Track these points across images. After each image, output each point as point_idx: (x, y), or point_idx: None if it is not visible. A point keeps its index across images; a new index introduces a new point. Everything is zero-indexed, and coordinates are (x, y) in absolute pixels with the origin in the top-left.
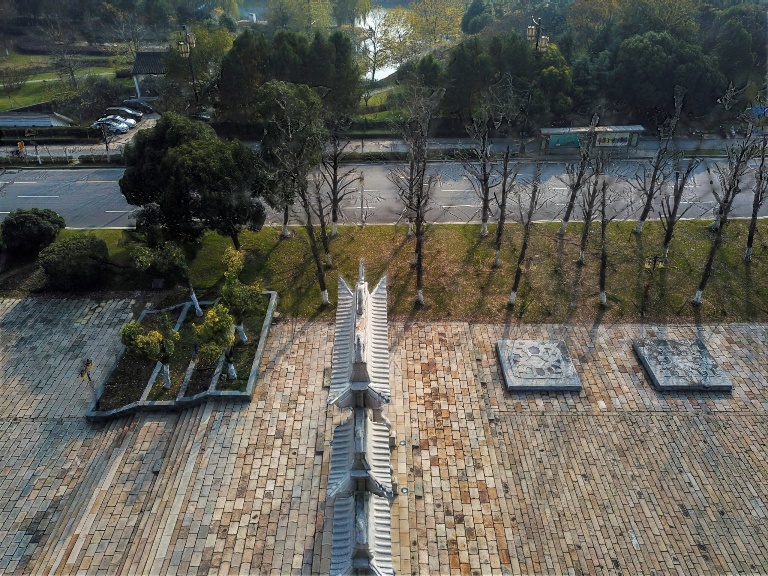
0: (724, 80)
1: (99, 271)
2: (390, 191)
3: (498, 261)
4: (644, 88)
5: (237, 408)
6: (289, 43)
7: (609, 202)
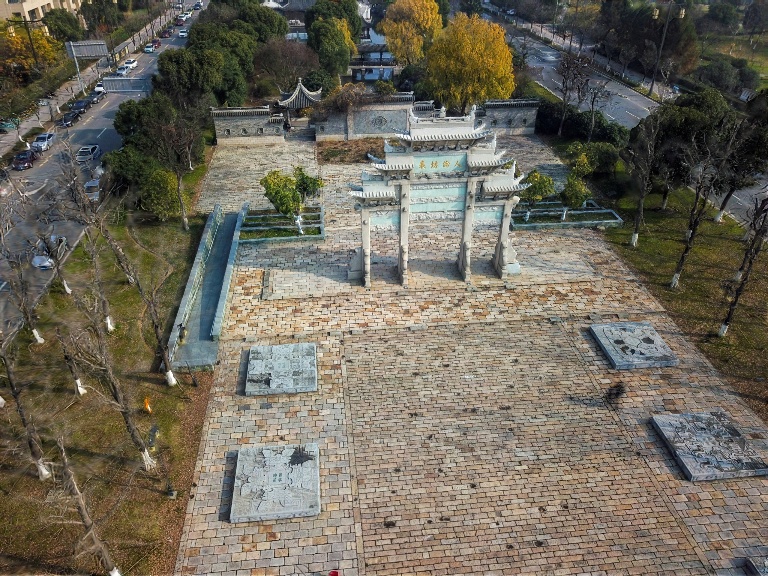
0: None
1: (597, 168)
2: None
3: None
4: None
5: None
6: None
7: None
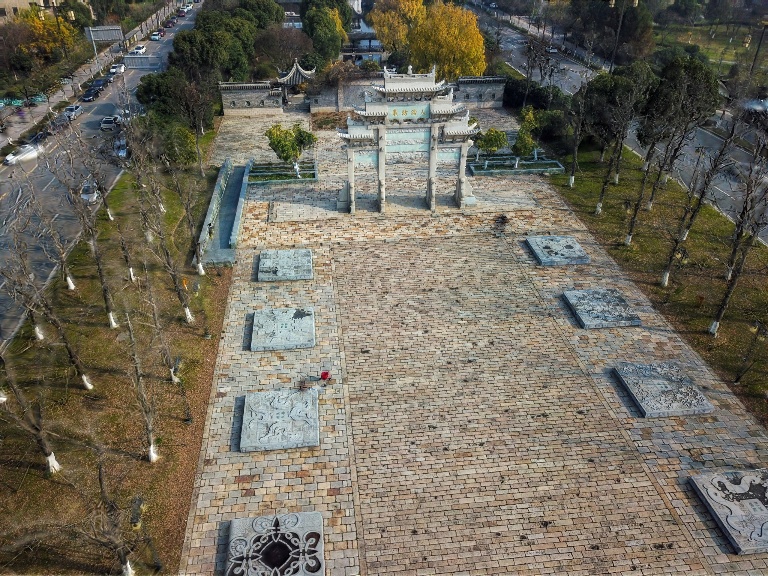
0: None
1: (550, 132)
2: None
3: None
4: None
5: (467, 174)
6: None
7: None
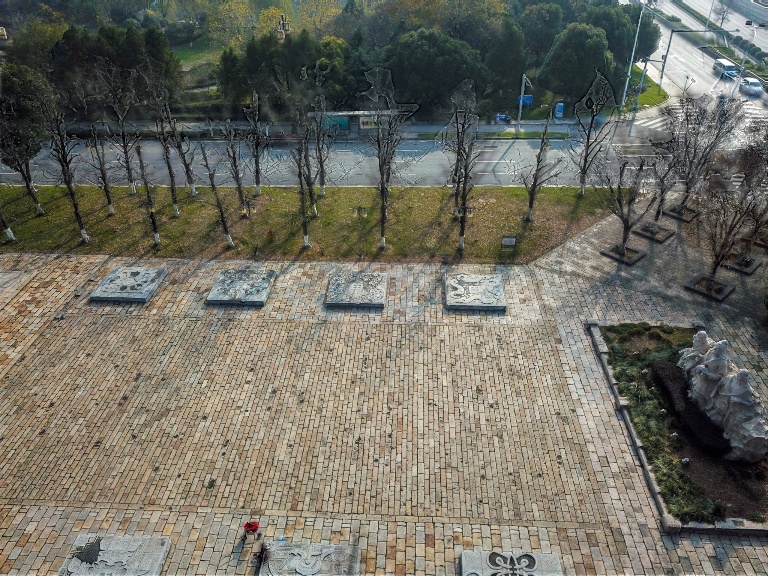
0: (486, 72)
1: None
2: (156, 162)
3: (176, 213)
4: (410, 78)
5: None
6: (103, 36)
7: (328, 173)
